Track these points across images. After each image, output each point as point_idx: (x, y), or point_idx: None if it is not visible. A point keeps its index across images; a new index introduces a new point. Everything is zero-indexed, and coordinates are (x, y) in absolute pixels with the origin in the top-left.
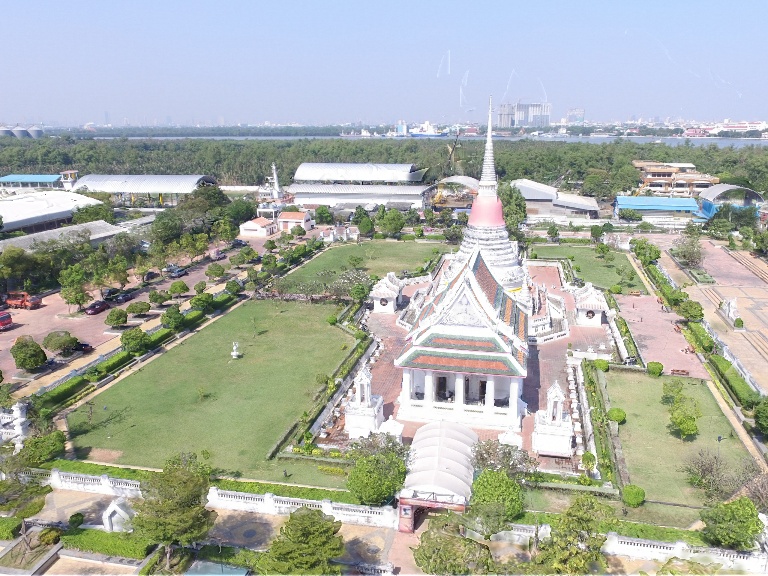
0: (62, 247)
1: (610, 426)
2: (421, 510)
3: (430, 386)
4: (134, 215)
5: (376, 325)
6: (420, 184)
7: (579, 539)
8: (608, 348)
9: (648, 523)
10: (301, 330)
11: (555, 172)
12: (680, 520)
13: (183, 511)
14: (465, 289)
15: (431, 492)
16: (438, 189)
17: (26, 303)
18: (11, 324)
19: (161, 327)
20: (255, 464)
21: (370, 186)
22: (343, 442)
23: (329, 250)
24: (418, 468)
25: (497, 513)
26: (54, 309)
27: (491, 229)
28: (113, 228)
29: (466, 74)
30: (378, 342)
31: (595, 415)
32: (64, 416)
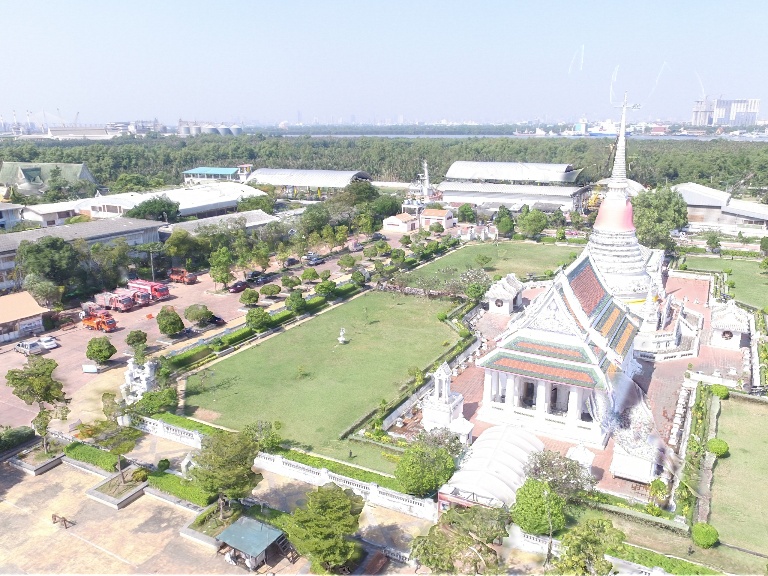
0: (220, 232)
1: (705, 457)
2: (461, 508)
3: (511, 390)
4: (293, 206)
5: (487, 325)
6: (573, 185)
7: (587, 561)
8: (740, 374)
9: (714, 567)
10: (410, 323)
11: (737, 176)
12: (756, 571)
13: (229, 469)
14: (554, 294)
15: (471, 492)
16: (593, 191)
17: (184, 279)
18: (168, 295)
19: (285, 309)
20: (327, 441)
21: (520, 186)
22: (416, 434)
23: (463, 248)
24: (467, 467)
25: (491, 517)
26: (206, 286)
27: (617, 234)
28: (268, 217)
29: (616, 69)
30: (483, 342)
31: (690, 443)
32: (186, 377)
